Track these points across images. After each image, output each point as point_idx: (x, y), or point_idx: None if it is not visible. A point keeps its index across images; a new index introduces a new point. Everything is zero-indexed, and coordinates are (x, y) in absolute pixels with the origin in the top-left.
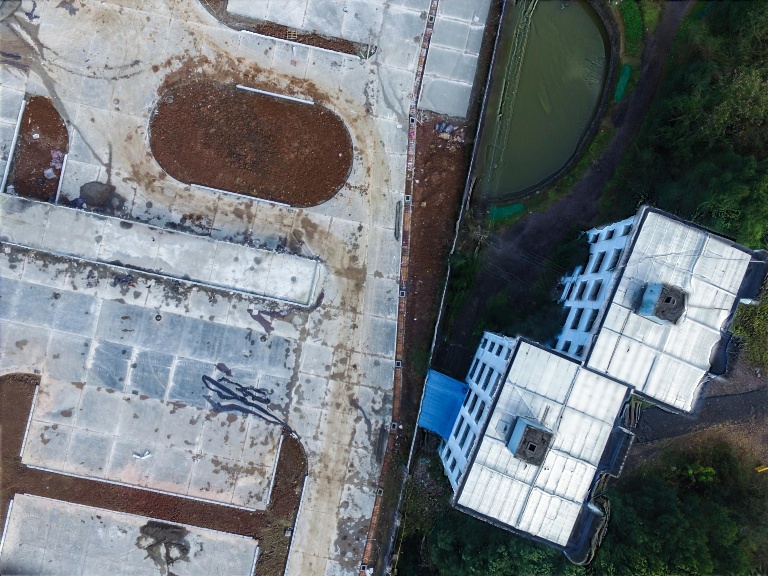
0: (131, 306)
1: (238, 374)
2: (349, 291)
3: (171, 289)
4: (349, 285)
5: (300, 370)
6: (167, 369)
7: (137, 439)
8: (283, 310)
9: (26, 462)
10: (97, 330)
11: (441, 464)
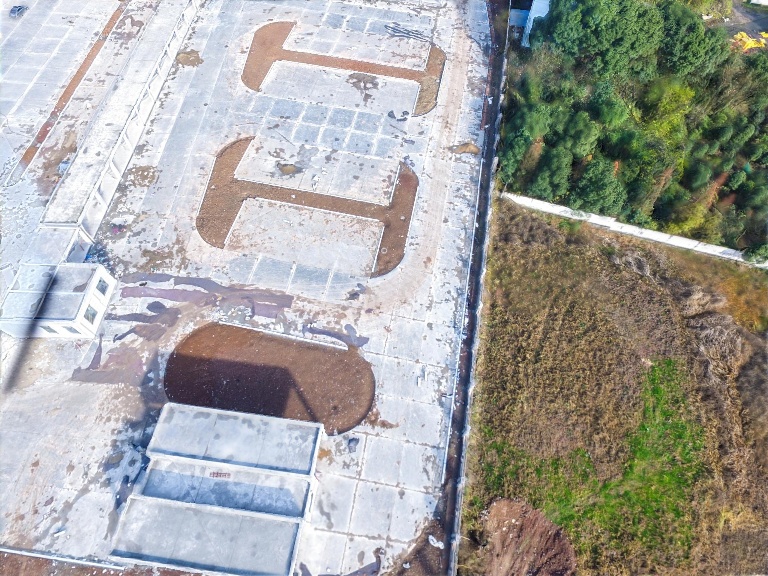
0: (347, 4)
1: (404, 26)
2: (460, 3)
3: (367, 1)
4: (460, 2)
5: (438, 26)
6: (365, 23)
7: (349, 43)
8: (426, 7)
9: (285, 48)
10: (328, 10)
11: (524, 53)
